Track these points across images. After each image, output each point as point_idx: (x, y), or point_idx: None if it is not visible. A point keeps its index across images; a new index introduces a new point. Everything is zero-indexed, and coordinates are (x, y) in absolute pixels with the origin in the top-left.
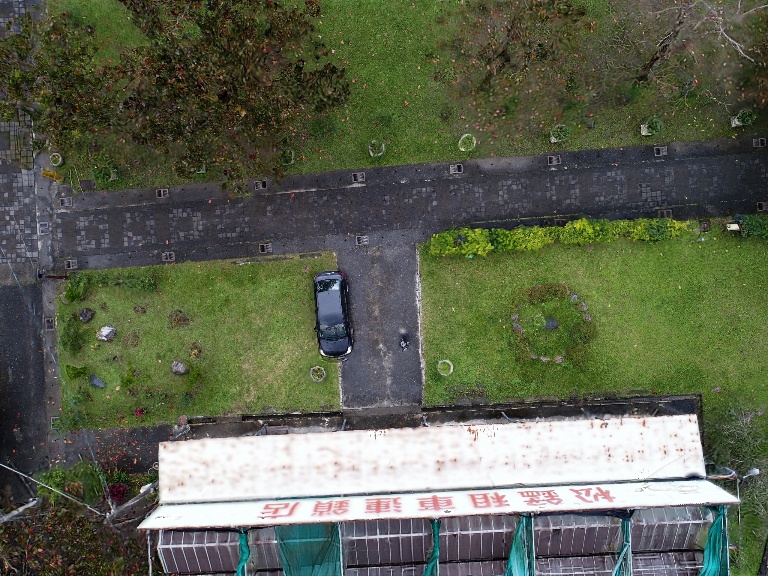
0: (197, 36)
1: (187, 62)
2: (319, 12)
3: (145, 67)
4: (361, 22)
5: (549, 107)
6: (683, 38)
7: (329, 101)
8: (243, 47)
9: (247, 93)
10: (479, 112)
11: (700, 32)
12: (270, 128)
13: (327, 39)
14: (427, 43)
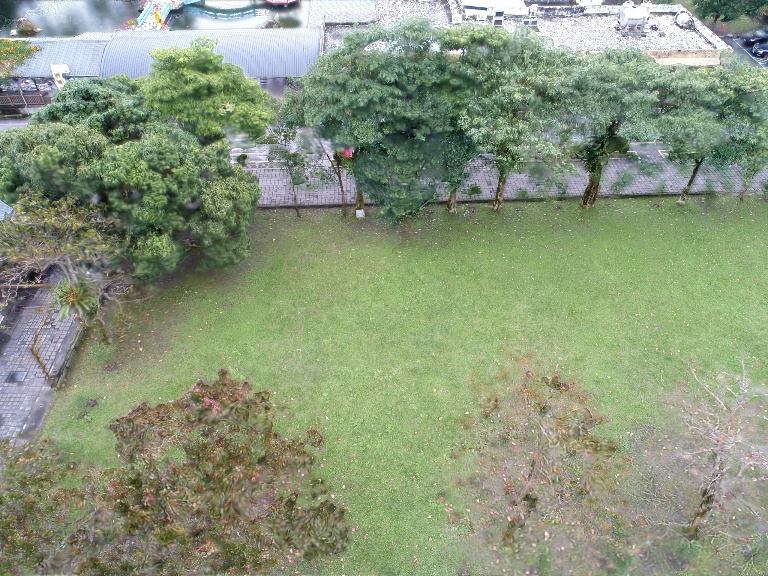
0: (180, 461)
1: (159, 486)
2: (322, 456)
3: (108, 491)
4: (366, 467)
5: (589, 569)
6: (722, 494)
7: (322, 546)
8: (229, 473)
9: (222, 527)
10: (505, 573)
11: (738, 488)
12: (242, 574)
13: (327, 483)
14: (438, 490)
